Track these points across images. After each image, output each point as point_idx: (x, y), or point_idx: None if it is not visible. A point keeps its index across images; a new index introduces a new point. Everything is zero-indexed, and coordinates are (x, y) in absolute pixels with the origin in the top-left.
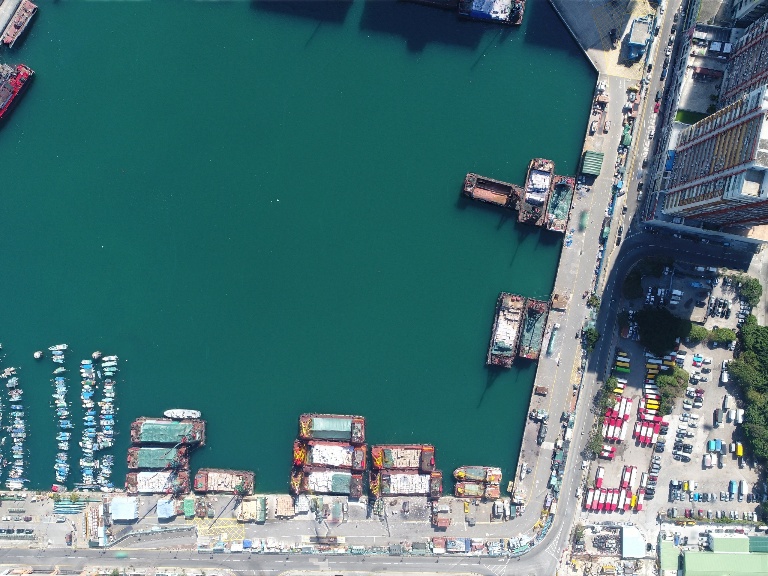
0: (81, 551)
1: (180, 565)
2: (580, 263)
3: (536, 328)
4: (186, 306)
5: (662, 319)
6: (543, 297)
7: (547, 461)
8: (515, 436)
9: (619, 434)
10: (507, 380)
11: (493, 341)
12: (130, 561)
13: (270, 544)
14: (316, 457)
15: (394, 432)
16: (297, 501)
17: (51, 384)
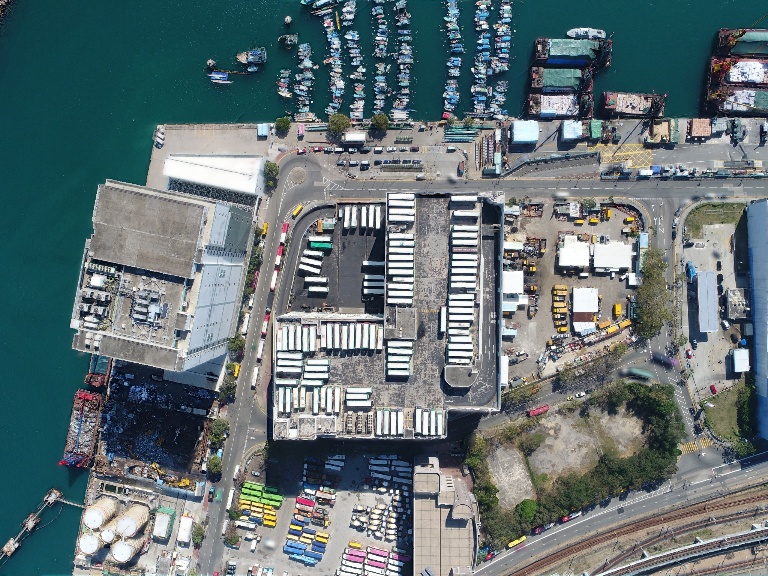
0: (472, 182)
1: (580, 195)
2: None
3: None
4: None
5: None
6: None
7: None
8: None
9: None
10: None
11: None
12: (526, 191)
13: (684, 166)
14: (733, 75)
15: None
16: (715, 120)
17: (442, 7)
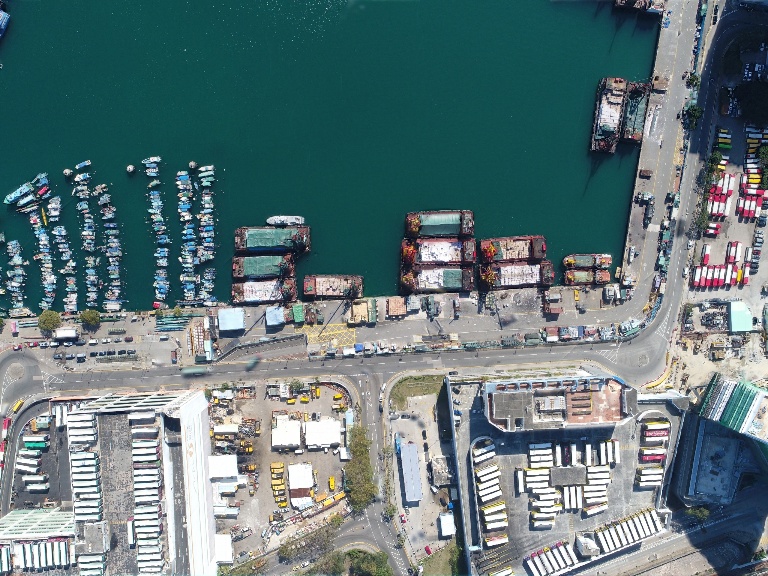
0: (187, 368)
1: (291, 375)
2: (678, 44)
3: (639, 109)
4: (284, 110)
5: (764, 88)
6: (643, 80)
7: (653, 243)
8: (620, 222)
9: (723, 210)
10: (610, 167)
11: (596, 126)
12: (239, 375)
13: (383, 344)
14: (425, 255)
15: (501, 226)
16: (409, 299)
17: (146, 199)
